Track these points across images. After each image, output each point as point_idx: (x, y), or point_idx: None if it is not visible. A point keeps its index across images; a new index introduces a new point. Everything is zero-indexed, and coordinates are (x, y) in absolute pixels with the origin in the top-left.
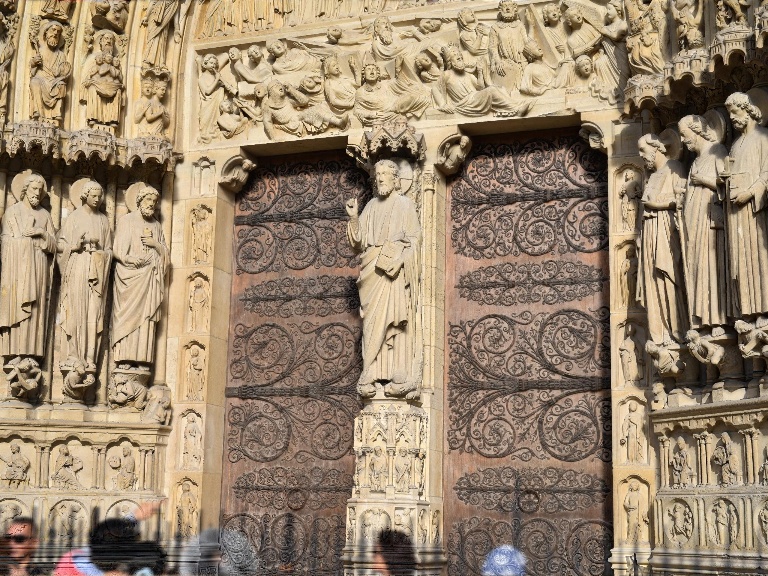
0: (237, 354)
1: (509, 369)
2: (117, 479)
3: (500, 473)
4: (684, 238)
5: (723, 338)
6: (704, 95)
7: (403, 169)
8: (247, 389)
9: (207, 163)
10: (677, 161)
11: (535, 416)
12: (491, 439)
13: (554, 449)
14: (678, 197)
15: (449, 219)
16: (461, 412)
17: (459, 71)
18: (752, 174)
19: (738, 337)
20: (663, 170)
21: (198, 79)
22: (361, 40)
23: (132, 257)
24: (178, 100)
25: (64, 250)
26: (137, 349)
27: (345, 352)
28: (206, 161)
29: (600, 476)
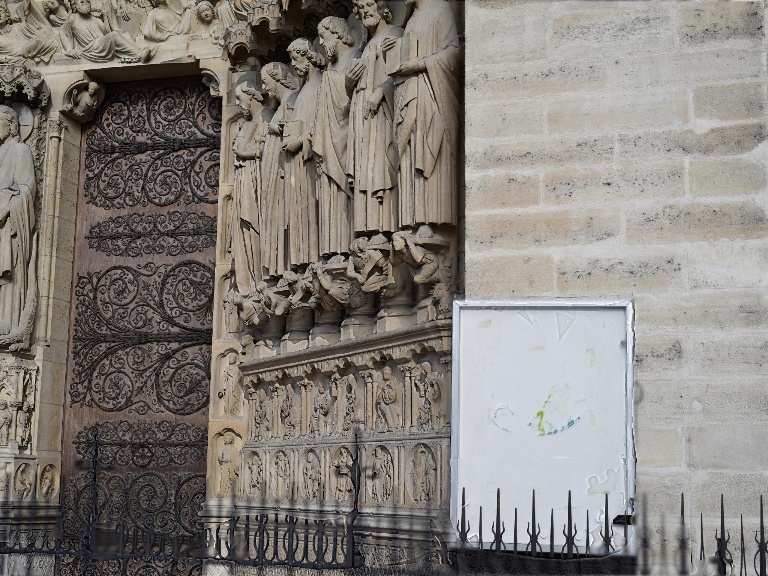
0: None
1: (131, 321)
2: None
3: (117, 427)
4: (260, 188)
5: (287, 289)
6: None
7: (24, 115)
8: None
9: None
10: (270, 110)
11: (153, 369)
12: (110, 392)
13: (169, 402)
14: (257, 146)
15: (83, 168)
16: (84, 365)
17: (85, 15)
18: (306, 122)
19: (289, 288)
20: (256, 119)
21: None
22: None
23: None
24: None
25: None
26: None
27: None
28: None
29: None
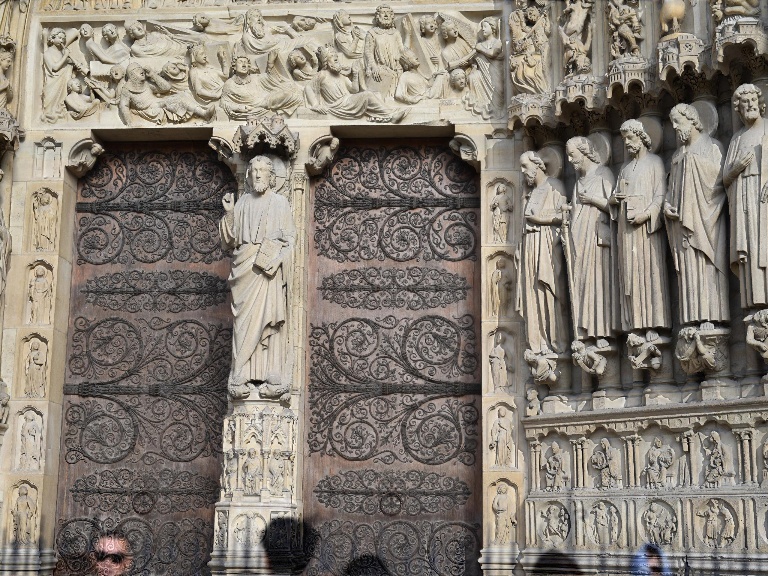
0: (77, 349)
1: (372, 373)
2: None
3: (362, 476)
4: (570, 253)
5: (608, 349)
6: (584, 118)
7: (276, 166)
8: (89, 386)
9: (51, 144)
10: (557, 179)
11: (398, 420)
12: (353, 442)
13: (417, 452)
14: (565, 214)
15: (312, 220)
16: (322, 414)
17: (334, 72)
18: (646, 197)
19: (629, 349)
20: (544, 187)
21: (44, 53)
22: (230, 31)
23: None
24: (21, 74)
25: None
26: None
27: (199, 350)
28: (50, 142)
29: (462, 479)
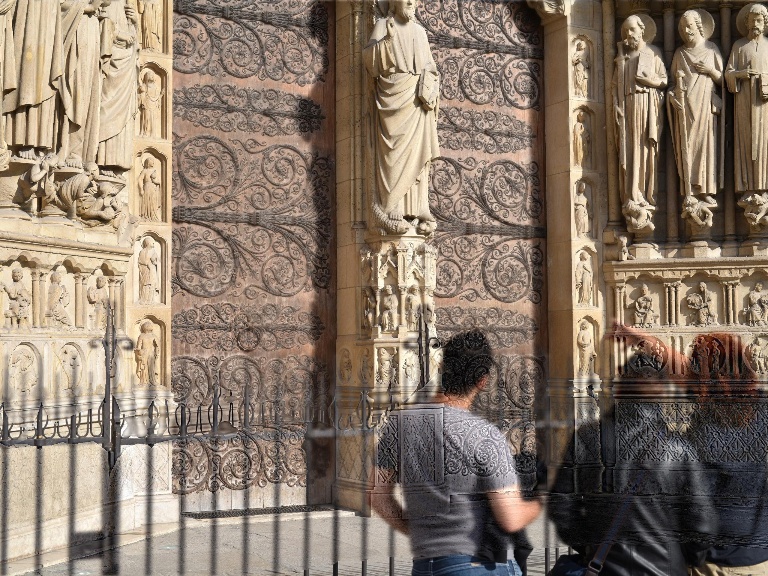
0: None
1: (457, 212)
2: (98, 316)
3: (451, 312)
4: (686, 117)
5: (716, 206)
6: None
7: None
8: (185, 211)
9: None
10: None
11: (479, 259)
12: (442, 279)
13: (495, 291)
14: None
15: None
16: None
17: None
18: None
19: (750, 207)
20: (647, 51)
21: None
22: None
23: (122, 32)
24: None
25: (72, 8)
26: (124, 152)
27: (296, 179)
28: None
29: (531, 316)
